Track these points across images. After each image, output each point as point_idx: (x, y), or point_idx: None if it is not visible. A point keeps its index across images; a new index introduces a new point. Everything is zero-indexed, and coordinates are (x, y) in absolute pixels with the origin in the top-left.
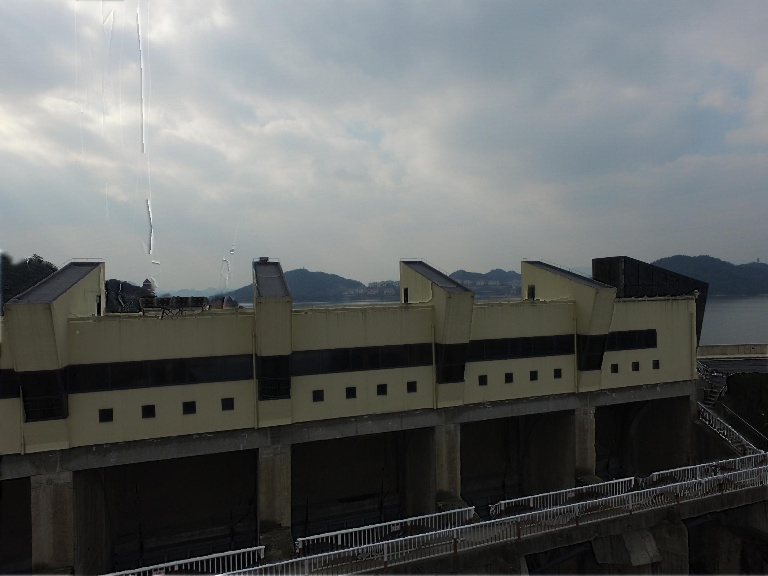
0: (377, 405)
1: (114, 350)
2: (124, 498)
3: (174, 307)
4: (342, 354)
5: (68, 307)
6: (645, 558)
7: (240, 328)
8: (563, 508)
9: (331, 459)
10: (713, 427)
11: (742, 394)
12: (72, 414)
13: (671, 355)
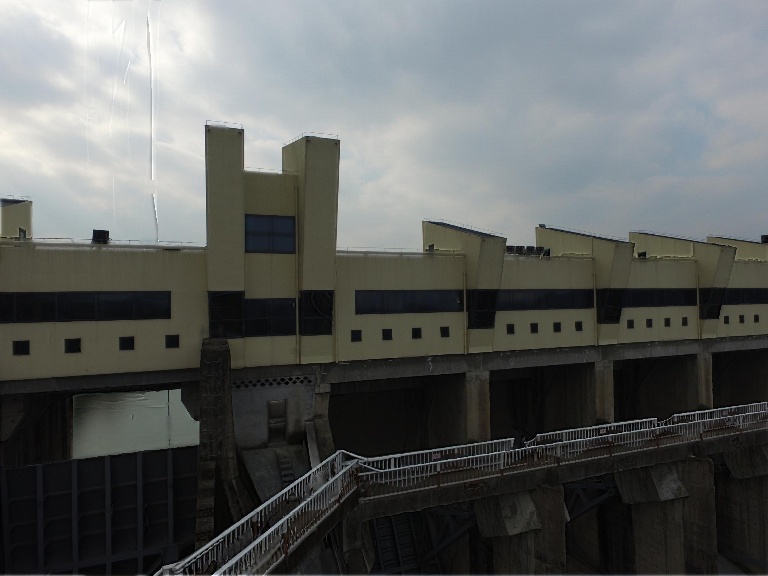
0: (664, 334)
1: (514, 280)
2: None
3: None
4: (643, 293)
5: None
6: None
7: (585, 269)
8: None
9: None
10: None
11: None
12: (495, 326)
13: None
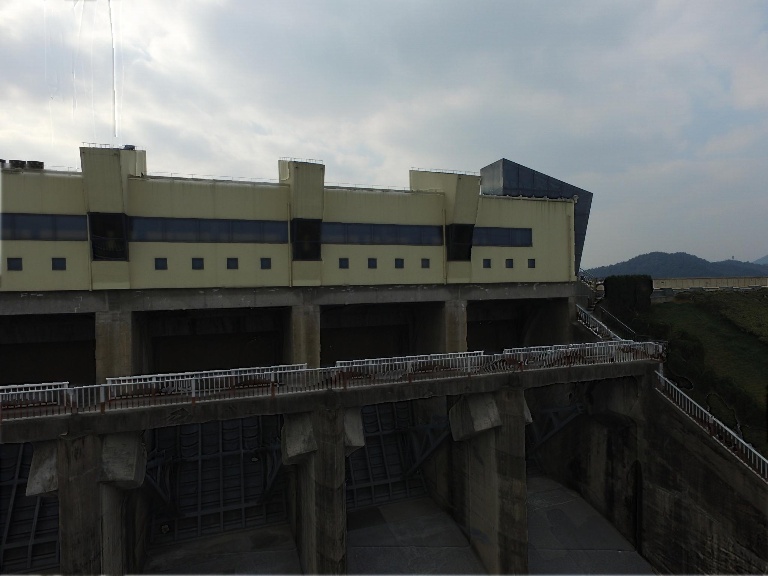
0: (227, 279)
1: None
2: None
3: None
4: (188, 224)
5: None
6: (487, 423)
7: (73, 188)
8: (395, 364)
9: (216, 366)
10: (588, 326)
11: (616, 294)
12: None
13: (548, 256)
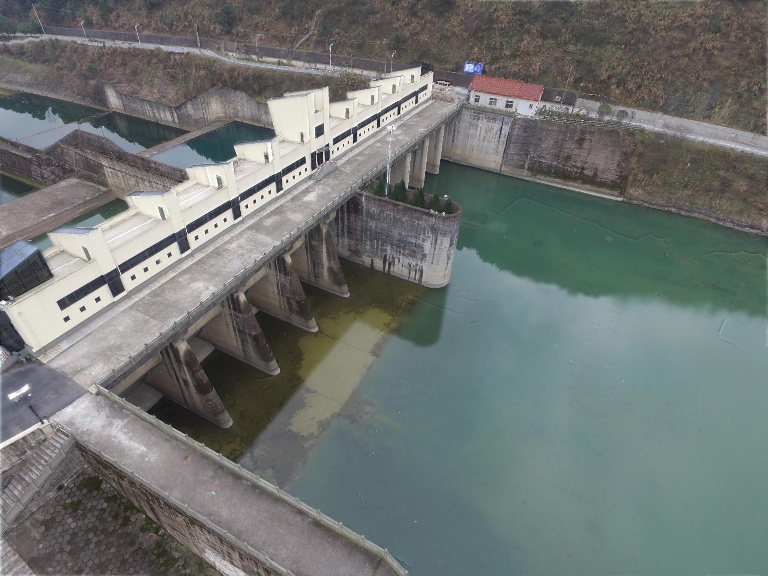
0: None
1: None
2: None
3: None
4: None
5: (243, 150)
6: None
7: None
8: None
9: None
10: None
11: None
12: None
13: None
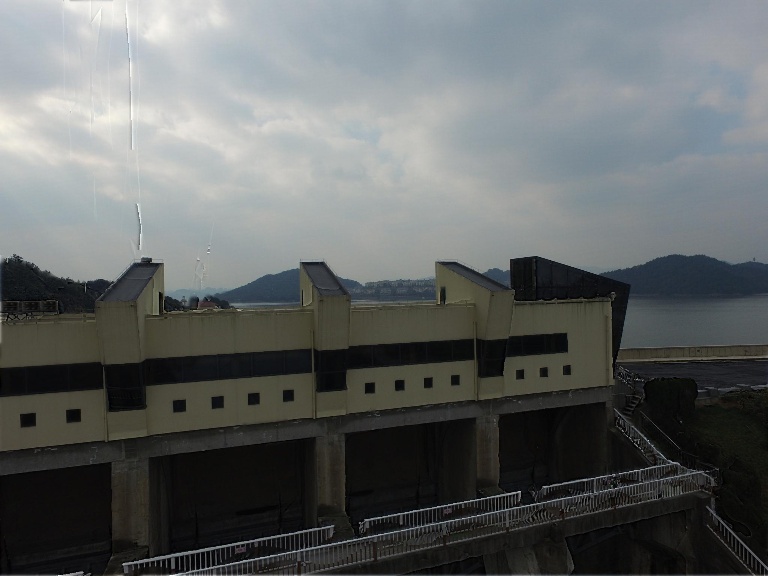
0: (248, 415)
1: None
2: (0, 512)
3: (22, 312)
4: (208, 361)
5: None
6: None
7: (88, 334)
8: (428, 527)
9: (235, 469)
10: (628, 435)
11: (658, 401)
12: None
13: (584, 360)
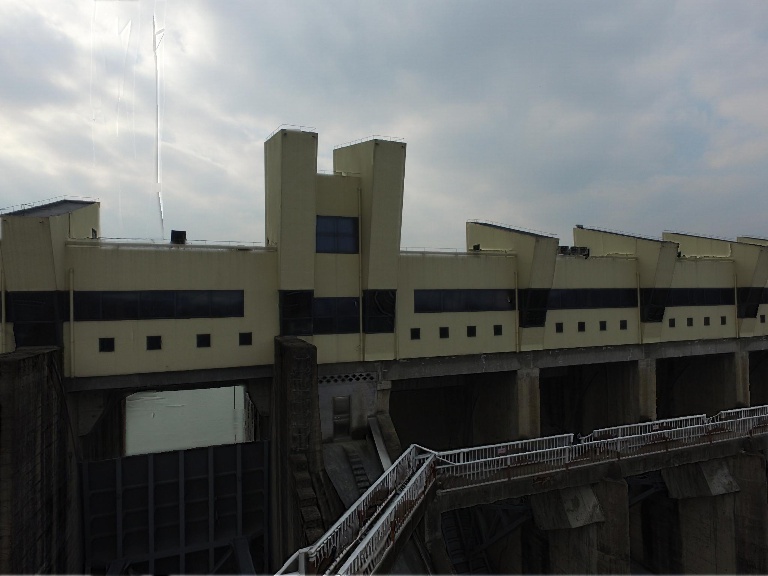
0: (704, 333)
1: (562, 280)
2: None
3: None
4: (684, 292)
5: None
6: None
7: (629, 268)
8: None
9: None
10: None
11: None
12: (545, 324)
13: None
